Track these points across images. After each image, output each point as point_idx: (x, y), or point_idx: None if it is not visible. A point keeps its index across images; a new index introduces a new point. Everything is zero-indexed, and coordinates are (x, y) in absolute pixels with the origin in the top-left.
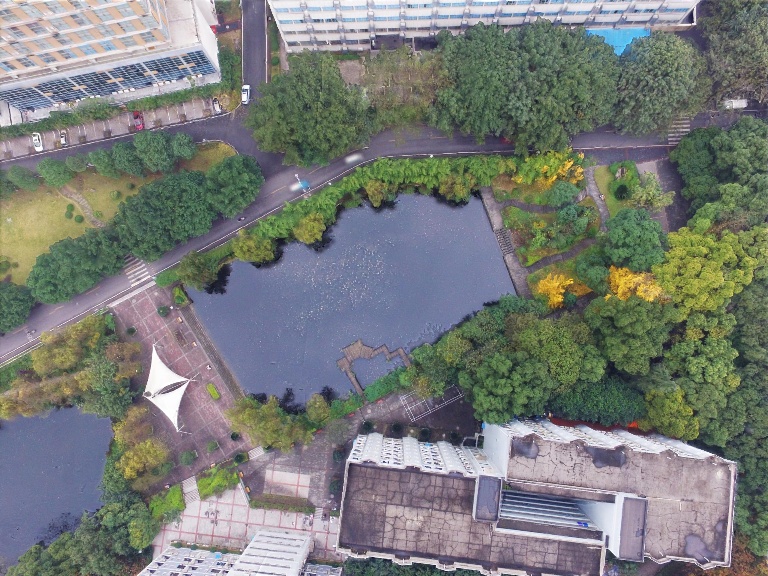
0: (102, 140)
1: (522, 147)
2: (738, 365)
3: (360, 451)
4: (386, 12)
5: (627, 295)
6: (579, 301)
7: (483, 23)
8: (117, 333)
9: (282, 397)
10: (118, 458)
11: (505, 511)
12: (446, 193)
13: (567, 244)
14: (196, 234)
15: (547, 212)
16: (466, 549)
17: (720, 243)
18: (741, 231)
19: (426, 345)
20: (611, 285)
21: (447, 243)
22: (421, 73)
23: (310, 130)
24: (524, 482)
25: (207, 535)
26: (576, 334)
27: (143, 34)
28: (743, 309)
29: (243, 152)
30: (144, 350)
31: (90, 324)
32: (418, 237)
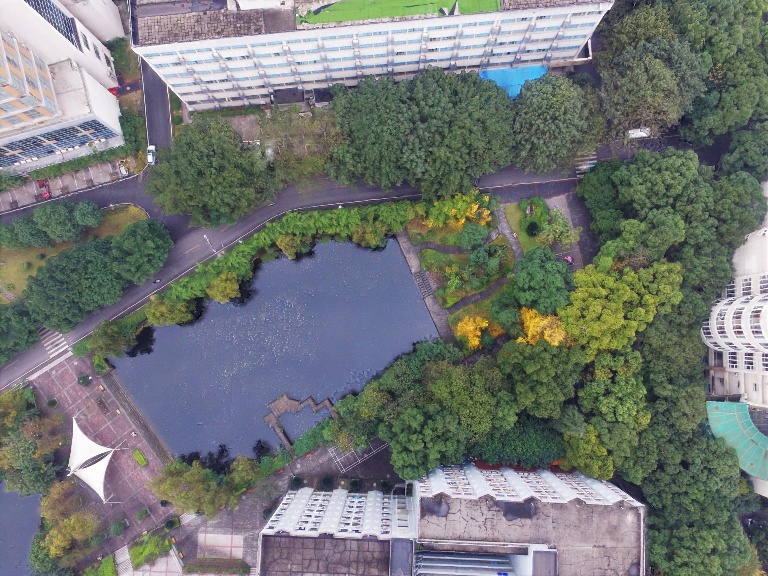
0: (9, 211)
1: (429, 192)
2: (652, 398)
3: (278, 517)
4: (277, 70)
5: (536, 338)
6: (500, 340)
7: (373, 76)
8: (38, 406)
9: (217, 453)
10: (44, 536)
11: (426, 566)
12: (360, 241)
13: (483, 284)
14: (107, 304)
15: (463, 252)
16: None
17: (621, 282)
18: (641, 269)
19: (349, 397)
20: (524, 326)
21: (367, 290)
22: (313, 132)
23: (206, 196)
24: (435, 542)
25: None
26: (489, 380)
27: (27, 112)
28: (649, 346)
29: (153, 213)
30: (67, 421)
31: (7, 401)
32: (337, 286)
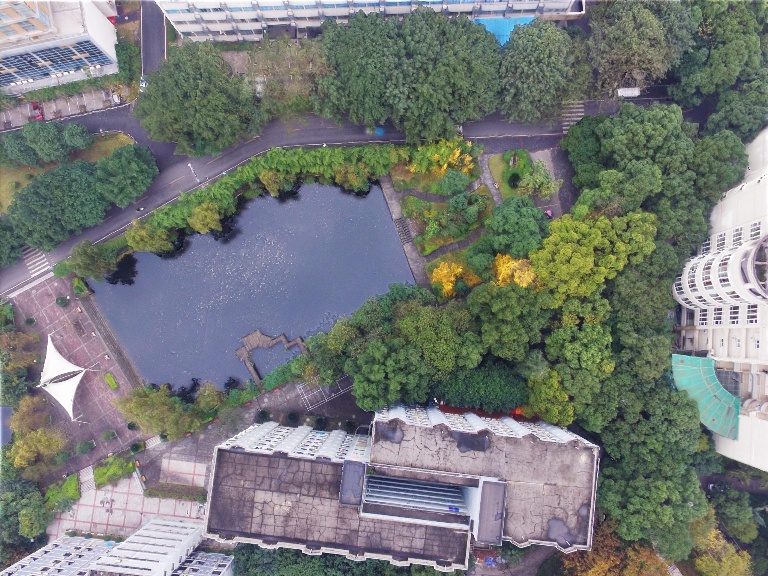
0: (2, 131)
1: (413, 136)
2: None
3: (237, 438)
4: (270, 1)
5: (507, 282)
6: None
7: None
8: (17, 323)
9: (189, 387)
10: (11, 447)
11: (380, 497)
12: (342, 182)
13: (461, 233)
14: (88, 224)
15: (444, 201)
16: (334, 534)
17: None
18: (615, 217)
19: (320, 334)
20: (498, 272)
21: (347, 233)
22: (298, 61)
23: (190, 118)
24: (387, 467)
25: (102, 524)
26: (457, 321)
27: (21, 23)
28: (618, 295)
29: (142, 143)
30: (43, 340)
31: None
32: (318, 227)
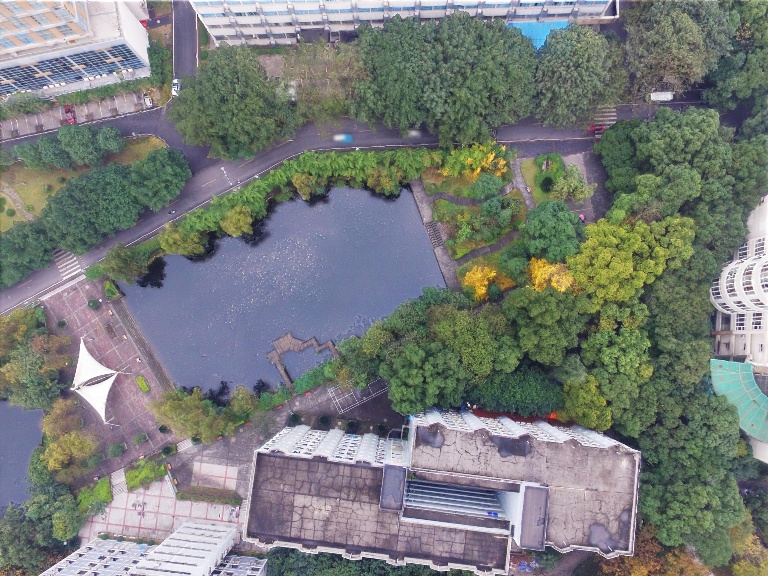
0: (34, 134)
1: (446, 140)
2: None
3: (274, 442)
4: (306, 5)
5: (543, 286)
6: (506, 293)
7: (399, 15)
8: (48, 326)
9: (218, 390)
10: (44, 450)
11: (417, 501)
12: (374, 186)
13: (494, 236)
14: (122, 227)
15: (475, 205)
16: (373, 539)
17: None
18: (653, 221)
19: (352, 337)
20: (532, 277)
21: (377, 236)
22: (336, 65)
23: (227, 122)
24: (428, 471)
25: (134, 527)
26: (493, 325)
27: (60, 27)
28: (656, 299)
29: (174, 146)
30: (75, 343)
31: (19, 317)
32: (349, 230)
